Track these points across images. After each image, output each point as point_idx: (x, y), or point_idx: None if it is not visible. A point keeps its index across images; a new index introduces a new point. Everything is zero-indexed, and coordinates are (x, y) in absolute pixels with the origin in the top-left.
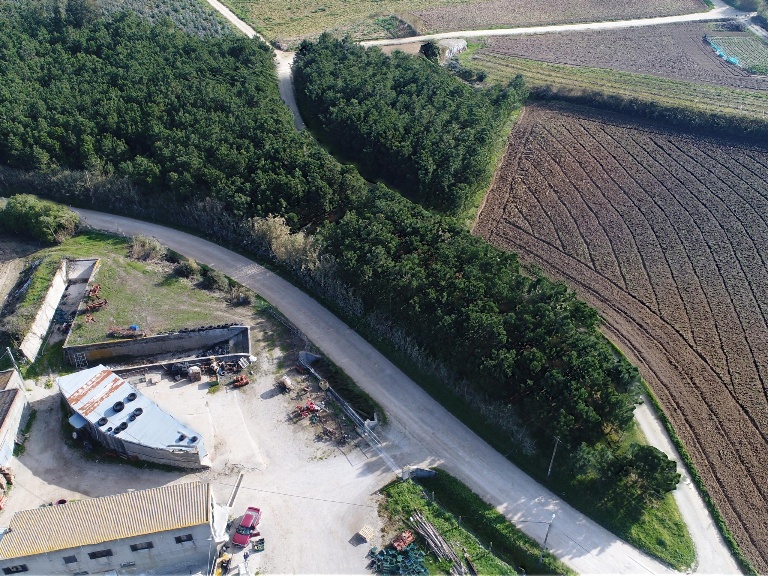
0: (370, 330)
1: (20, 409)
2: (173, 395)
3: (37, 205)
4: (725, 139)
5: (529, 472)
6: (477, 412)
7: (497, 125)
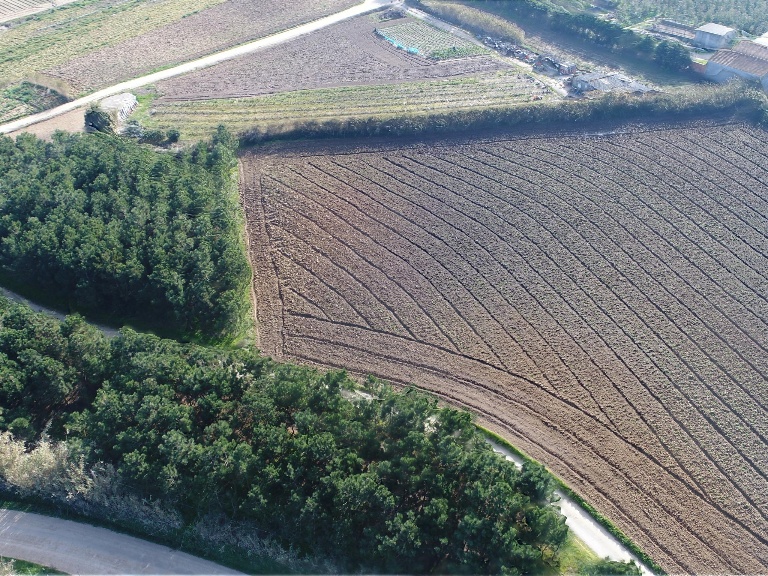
0: (202, 543)
1: None
2: None
3: None
4: (452, 138)
5: None
6: None
7: (224, 194)
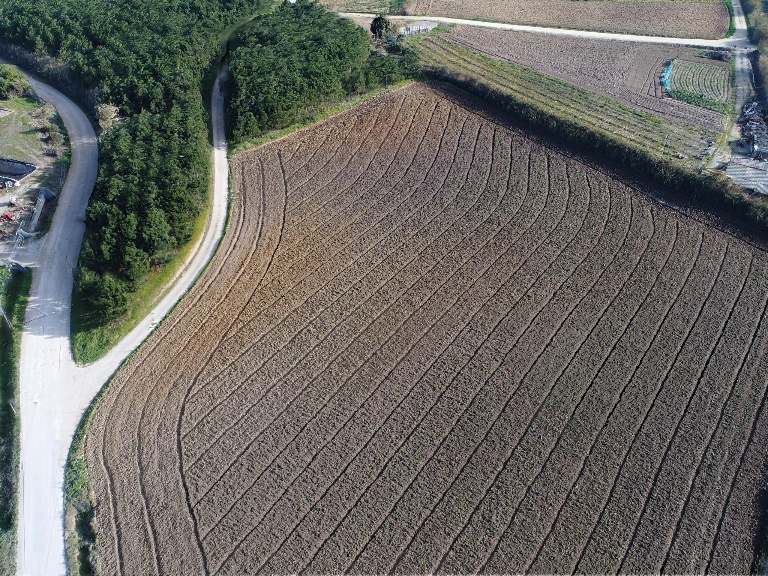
0: None
1: None
2: None
3: None
4: (549, 139)
5: None
6: None
7: (356, 86)
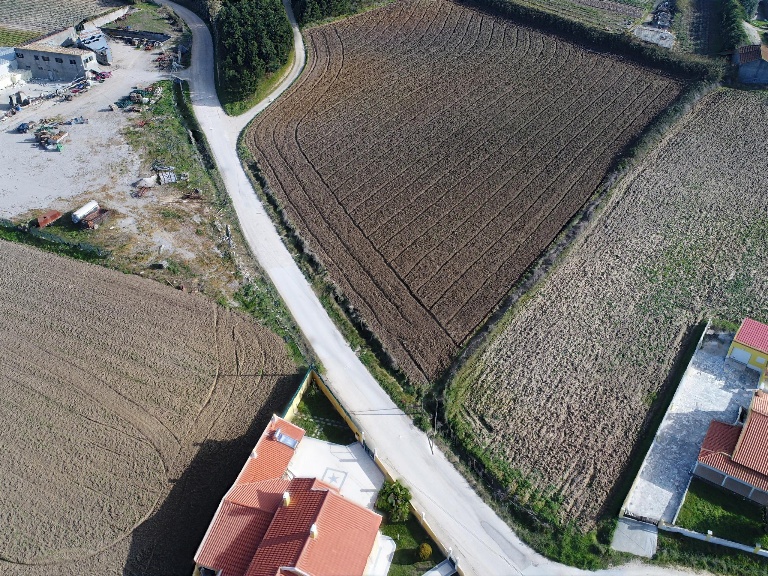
0: None
1: (66, 37)
2: (121, 47)
3: None
4: (519, 22)
5: None
6: None
7: None
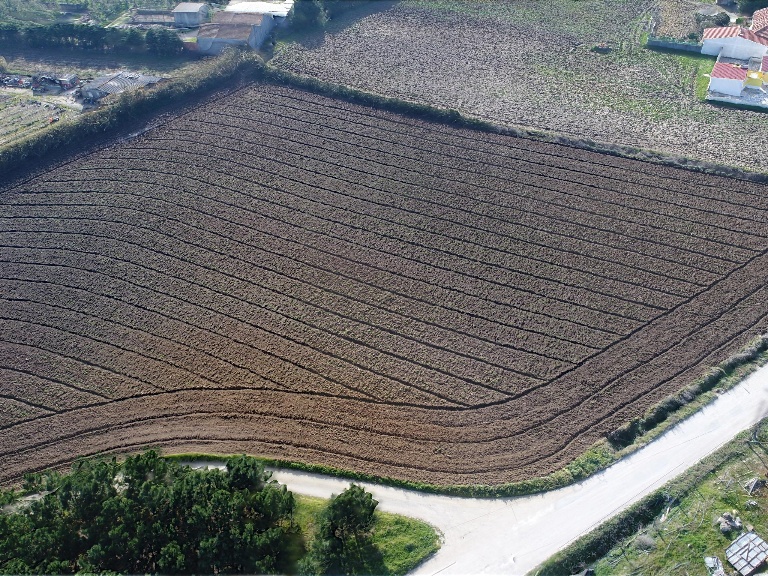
0: None
1: None
2: None
3: None
4: None
5: None
6: None
7: None
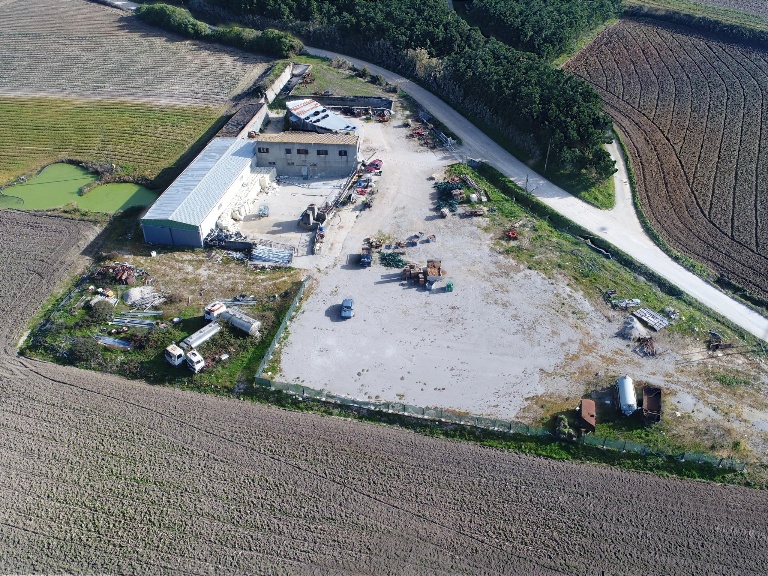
0: (465, 109)
1: (265, 113)
2: (345, 120)
3: (280, 33)
4: (765, 49)
5: (535, 169)
6: (515, 143)
7: (590, 23)
